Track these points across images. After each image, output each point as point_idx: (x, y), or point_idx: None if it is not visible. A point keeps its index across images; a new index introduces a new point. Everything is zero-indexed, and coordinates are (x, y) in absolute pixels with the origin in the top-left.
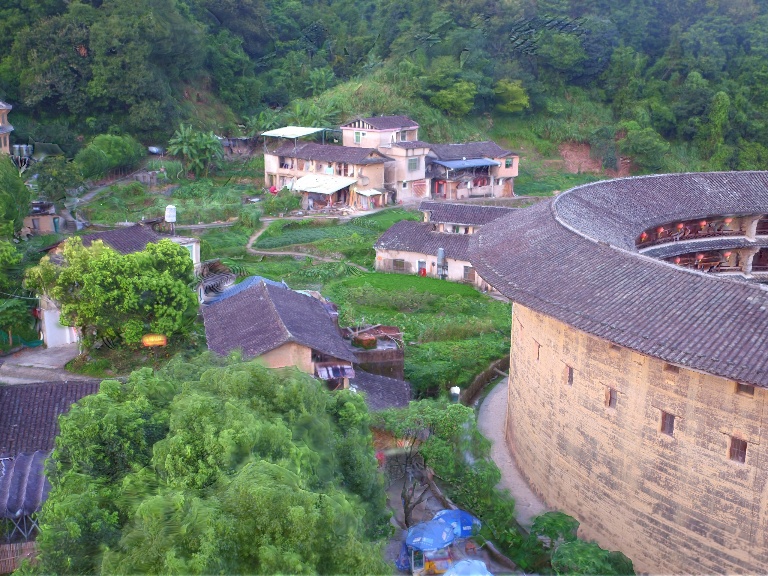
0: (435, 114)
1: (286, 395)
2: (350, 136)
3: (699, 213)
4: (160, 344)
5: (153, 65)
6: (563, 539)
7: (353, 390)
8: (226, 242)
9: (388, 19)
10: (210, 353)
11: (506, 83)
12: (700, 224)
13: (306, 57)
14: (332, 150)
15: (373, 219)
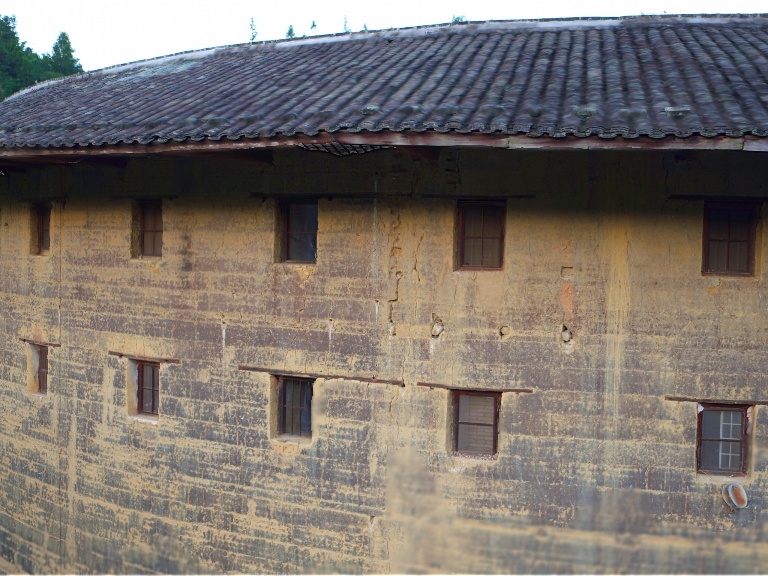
0: None
1: None
2: None
3: None
4: None
5: None
6: None
7: None
8: None
9: None
10: None
11: None
12: None
13: None
14: None
15: None
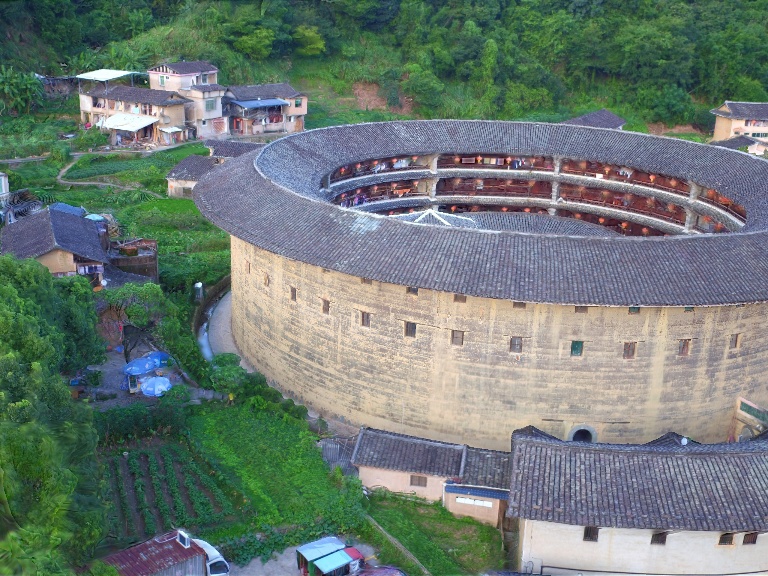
0: (238, 58)
1: (23, 274)
2: (156, 79)
3: (389, 153)
4: None
5: None
6: None
7: (104, 282)
8: (39, 174)
9: None
10: None
11: (303, 29)
12: (392, 161)
13: None
14: (138, 92)
15: (172, 153)
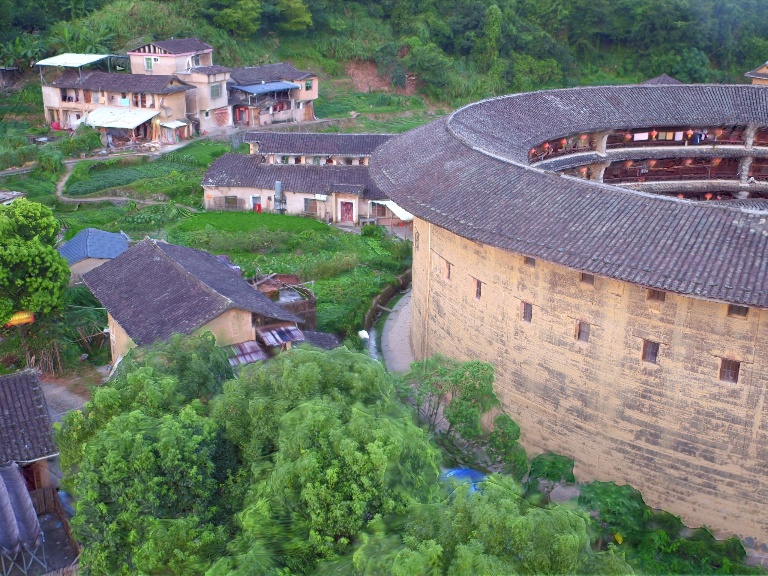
0: (221, 35)
1: (363, 384)
2: (140, 62)
3: (562, 132)
4: (26, 322)
5: None
6: (565, 480)
7: None
8: (31, 191)
9: None
10: (180, 336)
11: None
12: (561, 142)
13: None
14: (124, 79)
15: (185, 153)
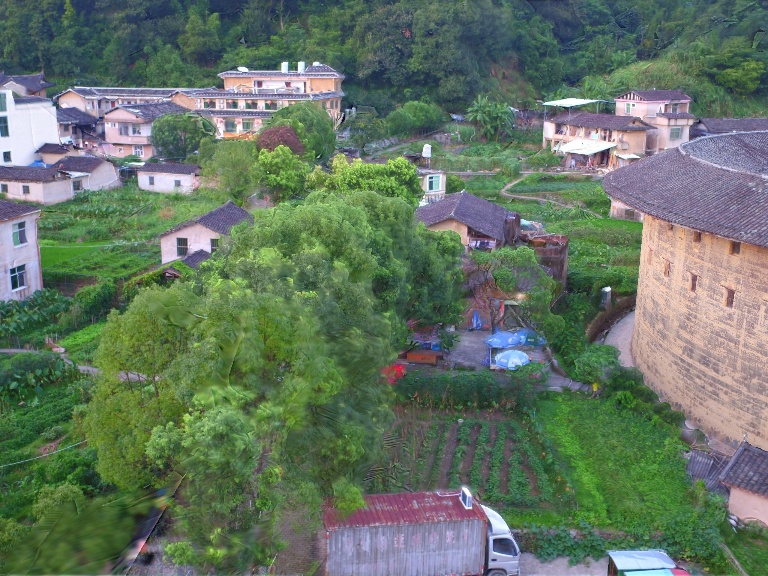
0: (718, 91)
1: (383, 207)
2: (622, 107)
3: None
4: None
5: (463, 45)
6: None
7: None
8: (485, 186)
9: (701, 4)
10: None
11: None
12: None
13: (612, 41)
14: (600, 118)
15: None
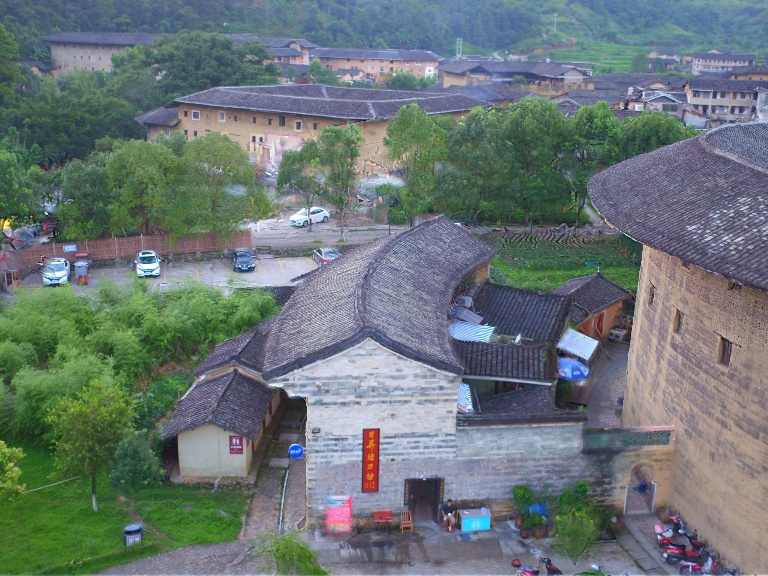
0: None
1: None
2: None
3: None
4: None
5: None
6: None
7: None
8: None
9: None
10: None
11: None
12: None
13: None
14: None
15: None
